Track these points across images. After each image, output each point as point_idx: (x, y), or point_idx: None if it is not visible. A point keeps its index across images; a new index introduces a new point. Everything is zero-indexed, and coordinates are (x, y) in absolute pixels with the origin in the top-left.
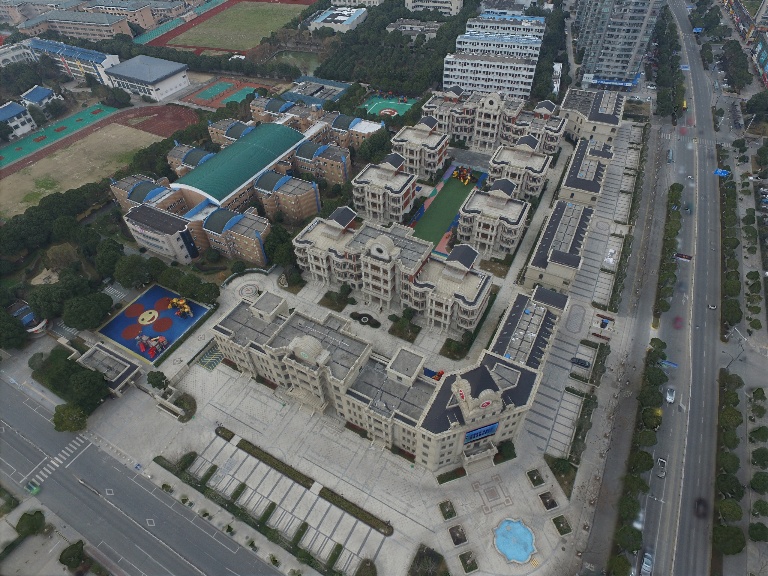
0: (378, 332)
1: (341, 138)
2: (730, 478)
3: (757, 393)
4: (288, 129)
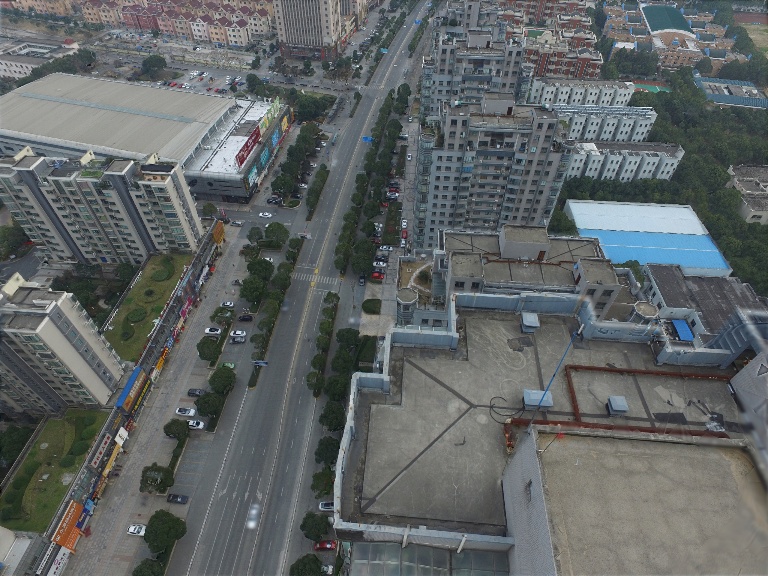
0: None
1: None
2: None
3: None
4: None
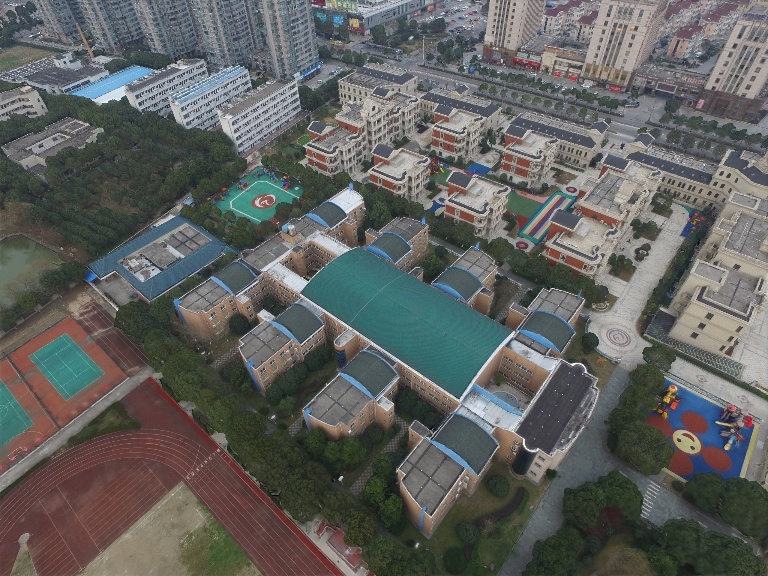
0: (655, 246)
1: (353, 227)
2: (739, 132)
3: (670, 115)
4: (345, 257)
